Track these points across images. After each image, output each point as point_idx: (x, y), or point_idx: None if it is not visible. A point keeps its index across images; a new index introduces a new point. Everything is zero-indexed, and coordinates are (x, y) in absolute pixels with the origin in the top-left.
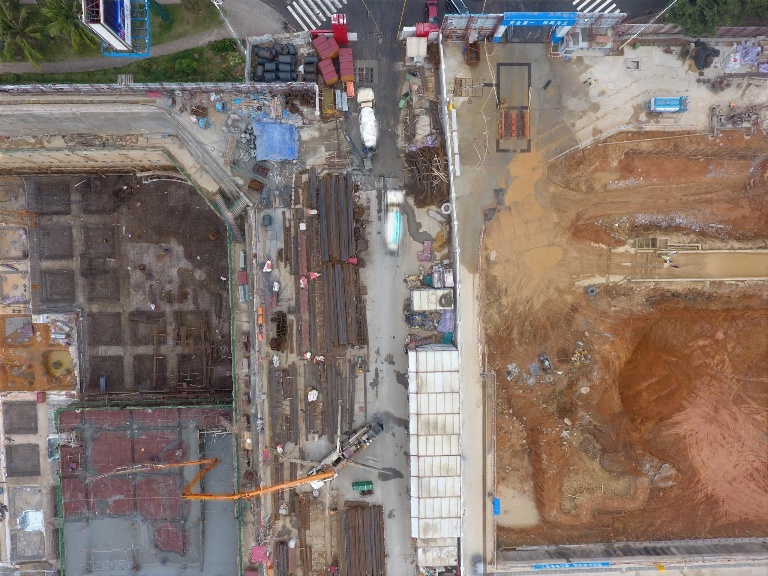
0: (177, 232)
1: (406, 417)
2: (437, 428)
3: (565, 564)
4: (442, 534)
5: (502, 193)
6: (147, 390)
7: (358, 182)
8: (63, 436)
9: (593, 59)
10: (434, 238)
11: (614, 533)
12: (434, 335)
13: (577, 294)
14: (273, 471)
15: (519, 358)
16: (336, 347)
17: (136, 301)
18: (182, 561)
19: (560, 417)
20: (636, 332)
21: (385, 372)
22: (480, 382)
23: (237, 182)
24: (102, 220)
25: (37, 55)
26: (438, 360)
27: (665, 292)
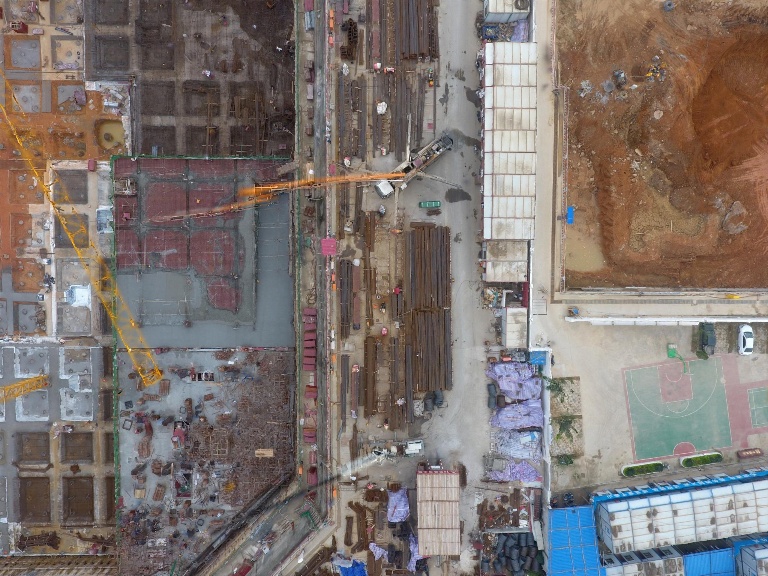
0: None
1: (475, 136)
2: (513, 123)
3: (635, 292)
4: (515, 235)
5: None
6: None
7: None
8: (118, 186)
9: None
10: None
11: (681, 281)
12: None
13: (653, 10)
14: (339, 188)
15: (593, 75)
16: (406, 60)
17: (190, 70)
18: (234, 319)
19: (631, 148)
20: (712, 55)
21: (455, 88)
22: (552, 99)
23: None
24: None
25: None
26: (516, 52)
27: (742, 16)
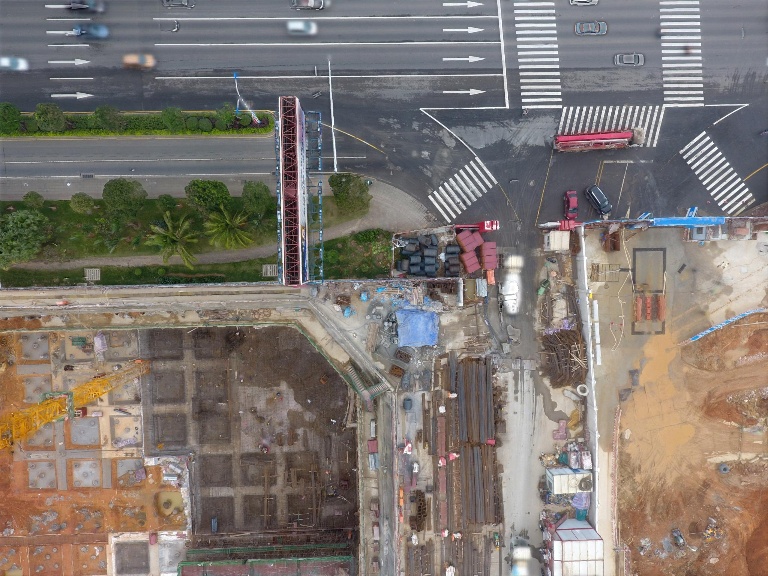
0: (288, 376)
1: None
2: None
3: None
4: None
5: (637, 374)
6: (258, 530)
7: (497, 366)
8: None
9: (727, 243)
10: (569, 417)
11: None
12: (568, 510)
13: (709, 471)
14: None
15: (652, 533)
16: (472, 524)
17: (247, 443)
18: None
19: None
20: (764, 504)
21: (520, 547)
22: (613, 556)
23: (379, 368)
24: (214, 365)
25: (194, 260)
26: (583, 549)
27: None
